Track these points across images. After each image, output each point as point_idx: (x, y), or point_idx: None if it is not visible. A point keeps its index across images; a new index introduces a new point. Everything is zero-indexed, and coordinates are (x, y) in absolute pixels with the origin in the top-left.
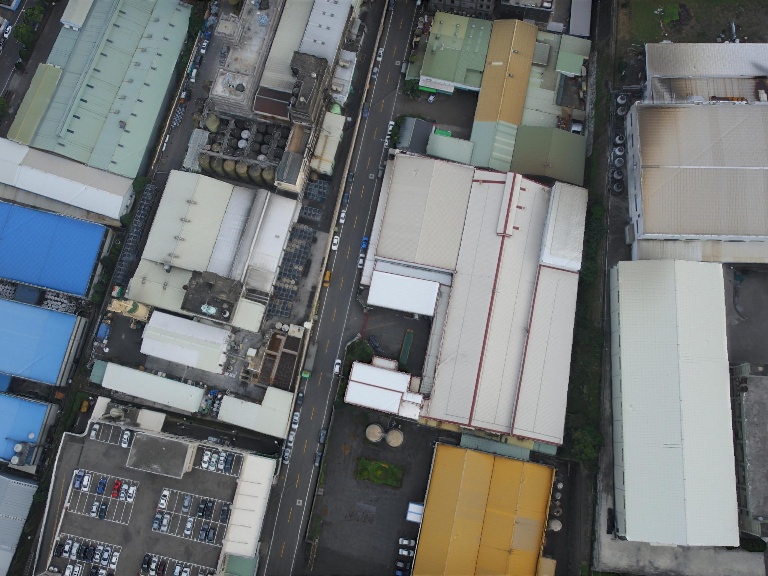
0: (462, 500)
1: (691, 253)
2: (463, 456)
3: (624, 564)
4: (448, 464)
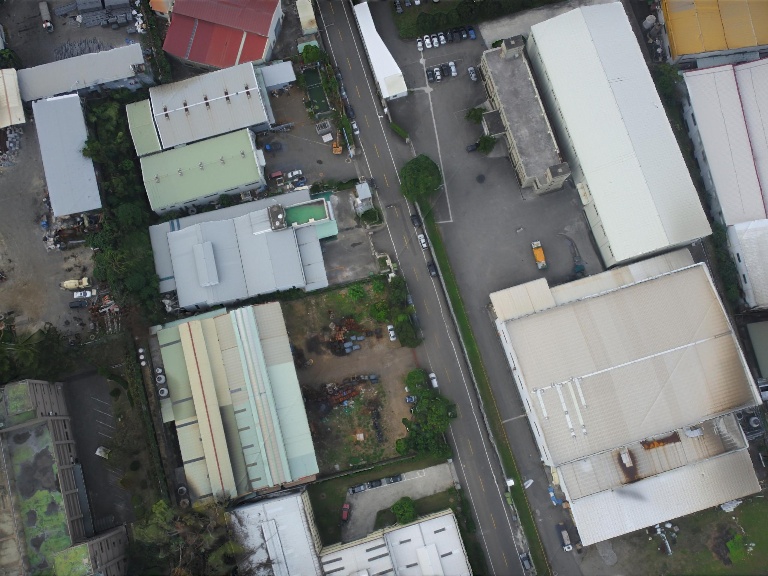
0: (744, 6)
1: (641, 270)
2: (759, 39)
3: (596, 1)
4: (767, 30)
